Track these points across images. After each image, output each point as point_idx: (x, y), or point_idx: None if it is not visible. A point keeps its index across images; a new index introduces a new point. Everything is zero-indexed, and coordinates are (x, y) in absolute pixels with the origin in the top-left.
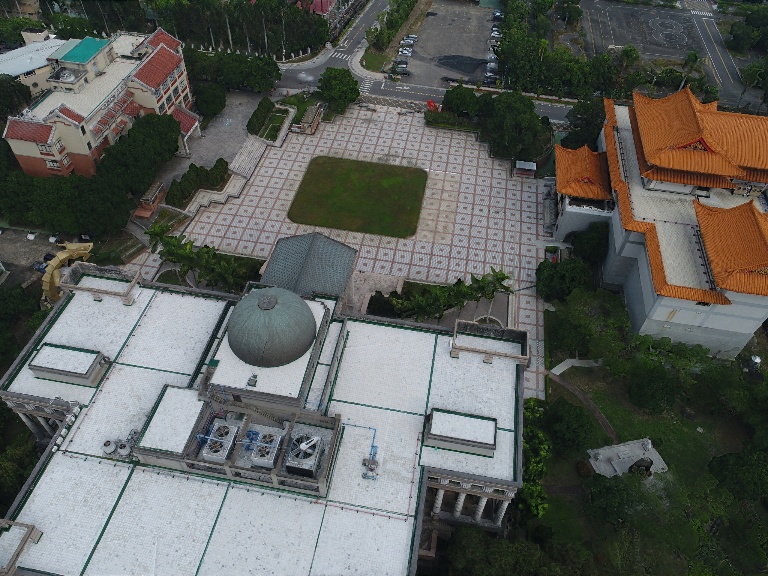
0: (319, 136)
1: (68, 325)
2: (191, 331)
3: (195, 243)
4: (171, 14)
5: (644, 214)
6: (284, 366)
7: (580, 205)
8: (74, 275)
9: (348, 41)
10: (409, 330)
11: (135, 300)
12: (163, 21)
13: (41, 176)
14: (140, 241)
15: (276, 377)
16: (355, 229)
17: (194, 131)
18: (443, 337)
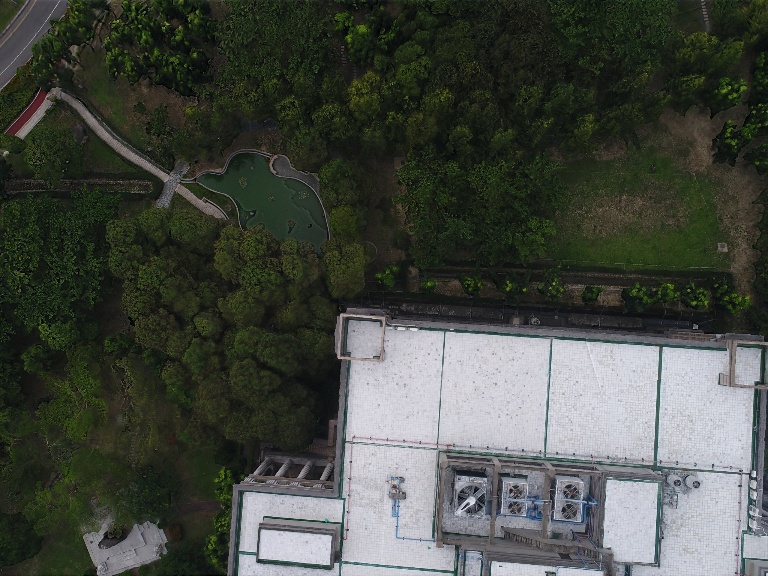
0: None
1: None
2: None
3: None
4: None
5: None
6: None
7: None
8: None
9: None
10: None
11: None
12: None
13: None
14: None
15: None
16: None
17: None
18: None
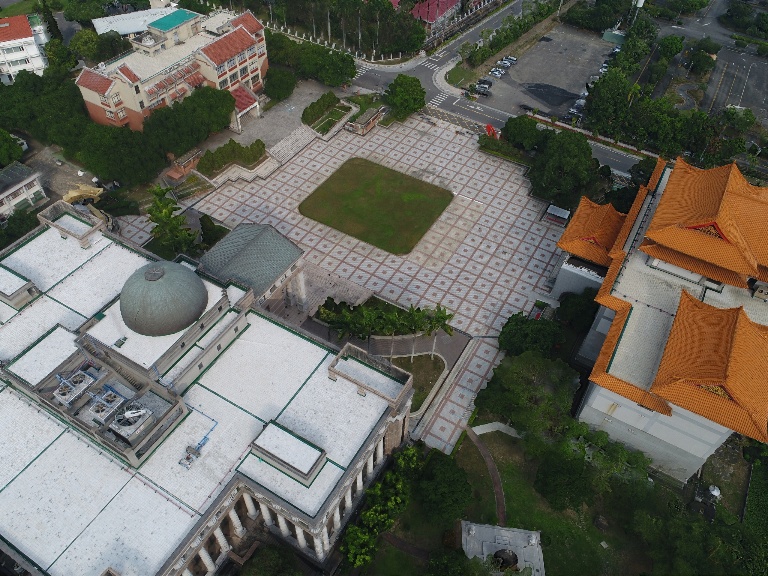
0: (368, 138)
1: (30, 252)
2: (119, 285)
3: (206, 211)
4: (285, 1)
5: (629, 291)
6: (155, 337)
7: (580, 265)
8: (56, 211)
9: (445, 52)
10: (306, 340)
11: (92, 245)
12: (275, 6)
13: (101, 123)
14: None
15: (142, 345)
16: (353, 234)
17: (254, 110)
18: (333, 356)
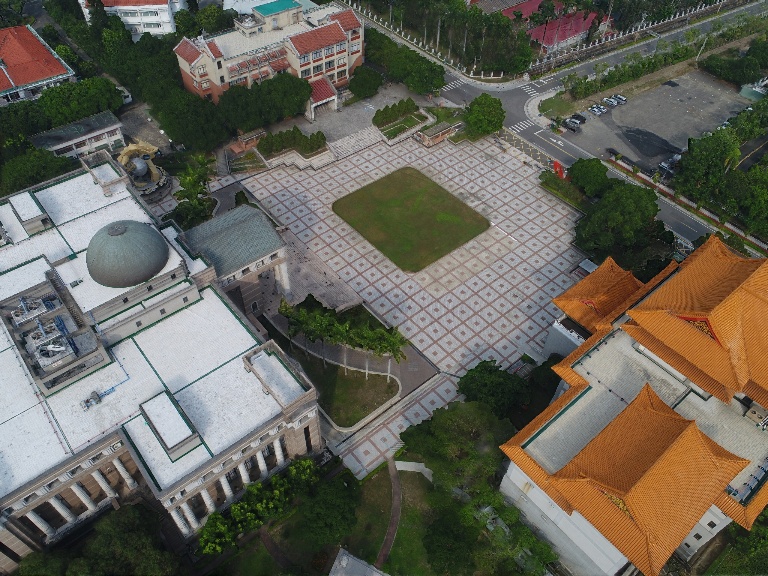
0: (432, 151)
1: (64, 189)
2: None
3: (250, 188)
4: None
5: (596, 369)
6: (105, 287)
7: (574, 329)
8: (98, 158)
9: (551, 79)
10: (243, 326)
11: (113, 195)
12: None
13: None
14: (216, 168)
15: (91, 290)
16: (372, 241)
17: (332, 103)
18: None
